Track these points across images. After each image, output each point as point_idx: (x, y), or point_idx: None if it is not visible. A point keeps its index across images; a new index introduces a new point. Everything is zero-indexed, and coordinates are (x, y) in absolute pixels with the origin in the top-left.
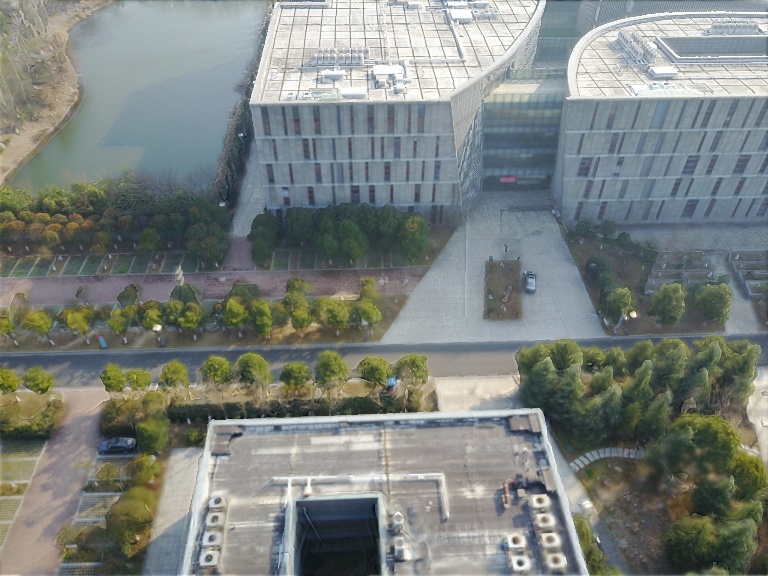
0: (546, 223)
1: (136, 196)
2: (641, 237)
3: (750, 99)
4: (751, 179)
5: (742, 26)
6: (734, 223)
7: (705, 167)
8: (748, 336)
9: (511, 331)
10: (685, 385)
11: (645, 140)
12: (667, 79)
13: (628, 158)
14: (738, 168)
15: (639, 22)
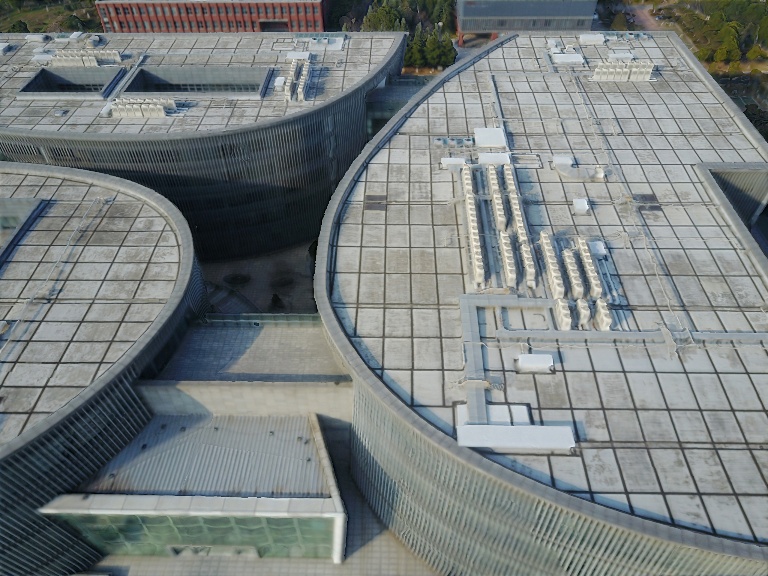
0: None
1: (760, 121)
2: None
3: None
4: None
5: None
6: None
7: None
8: None
9: None
10: None
11: None
12: None
13: None
14: None
15: None
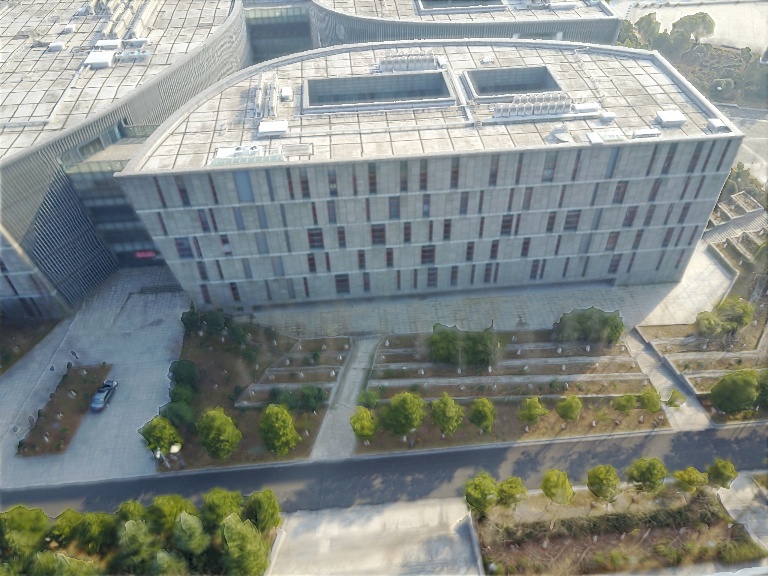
0: (176, 308)
1: None
2: (293, 318)
3: (347, 164)
4: (399, 249)
5: (415, 60)
6: (407, 295)
7: (335, 240)
8: (334, 463)
9: (40, 471)
10: (149, 569)
11: (241, 215)
12: (272, 138)
13: (232, 235)
14: (378, 238)
15: (307, 58)
